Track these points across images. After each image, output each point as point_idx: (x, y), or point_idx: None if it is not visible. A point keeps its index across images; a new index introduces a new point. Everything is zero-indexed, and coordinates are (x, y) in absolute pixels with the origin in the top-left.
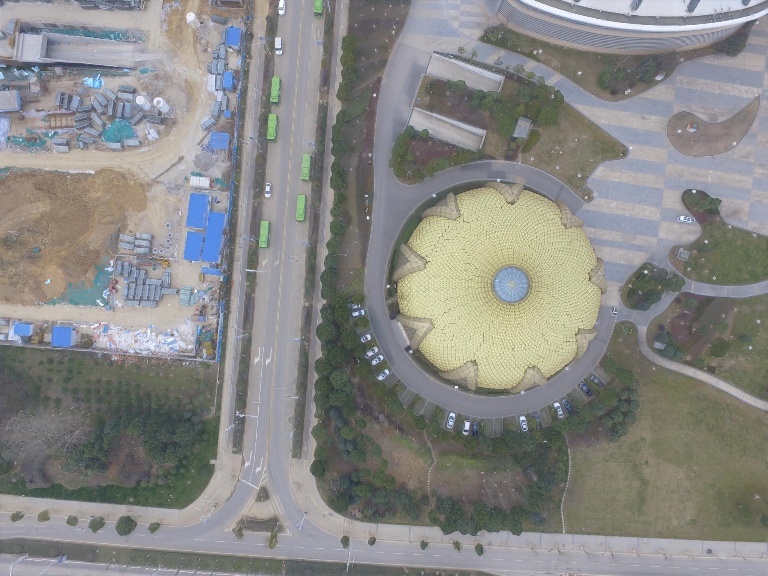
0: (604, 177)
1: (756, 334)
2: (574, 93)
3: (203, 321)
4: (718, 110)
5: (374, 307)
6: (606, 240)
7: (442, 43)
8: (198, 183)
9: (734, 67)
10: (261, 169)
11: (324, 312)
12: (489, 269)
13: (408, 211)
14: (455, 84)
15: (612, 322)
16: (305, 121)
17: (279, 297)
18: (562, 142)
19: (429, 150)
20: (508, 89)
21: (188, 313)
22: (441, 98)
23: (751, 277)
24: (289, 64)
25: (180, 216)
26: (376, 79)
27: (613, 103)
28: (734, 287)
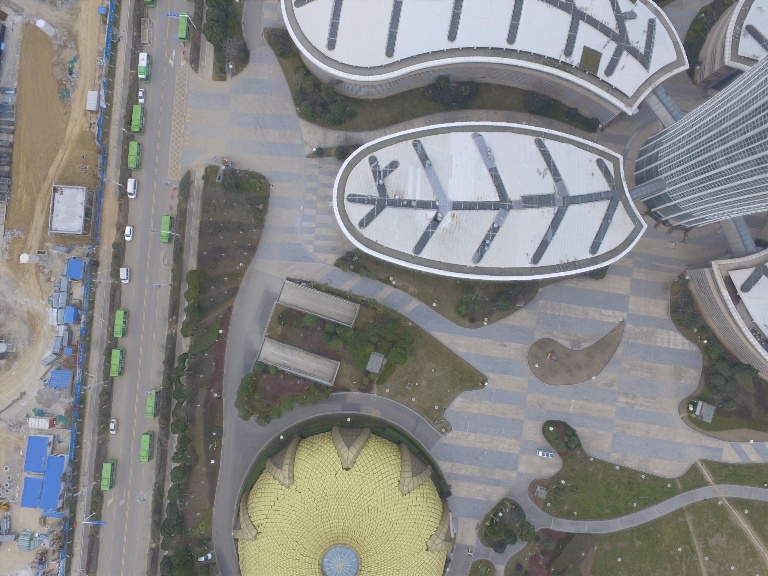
0: (462, 408)
1: (616, 573)
2: (432, 320)
3: (43, 568)
4: (581, 336)
5: (222, 549)
6: (463, 475)
7: (296, 269)
8: (37, 425)
9: (598, 290)
10: (106, 404)
11: (161, 569)
12: (317, 549)
13: (259, 447)
14: (303, 321)
15: (469, 561)
16: (153, 352)
17: (124, 538)
18: (418, 373)
19: (280, 384)
20: (364, 317)
21: (29, 558)
22: (293, 329)
23: (613, 512)
24: (137, 292)
25: (21, 455)
26: (226, 308)
27: (472, 330)
28: (595, 522)
